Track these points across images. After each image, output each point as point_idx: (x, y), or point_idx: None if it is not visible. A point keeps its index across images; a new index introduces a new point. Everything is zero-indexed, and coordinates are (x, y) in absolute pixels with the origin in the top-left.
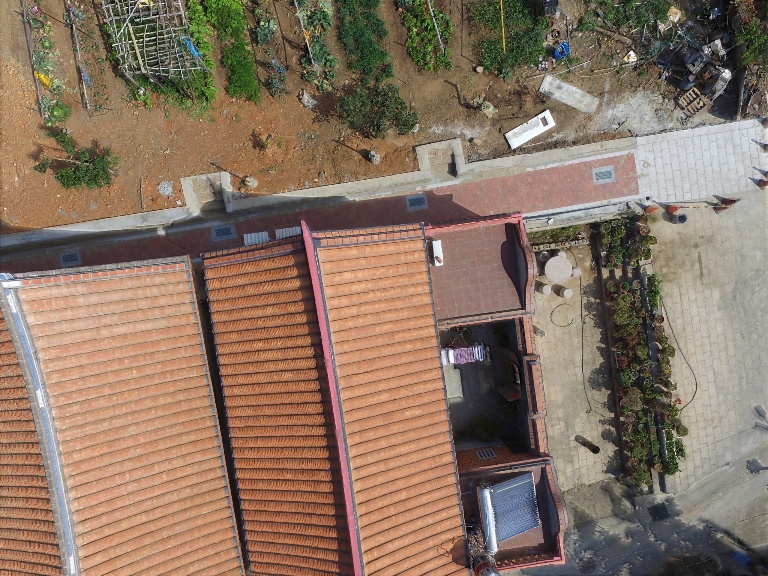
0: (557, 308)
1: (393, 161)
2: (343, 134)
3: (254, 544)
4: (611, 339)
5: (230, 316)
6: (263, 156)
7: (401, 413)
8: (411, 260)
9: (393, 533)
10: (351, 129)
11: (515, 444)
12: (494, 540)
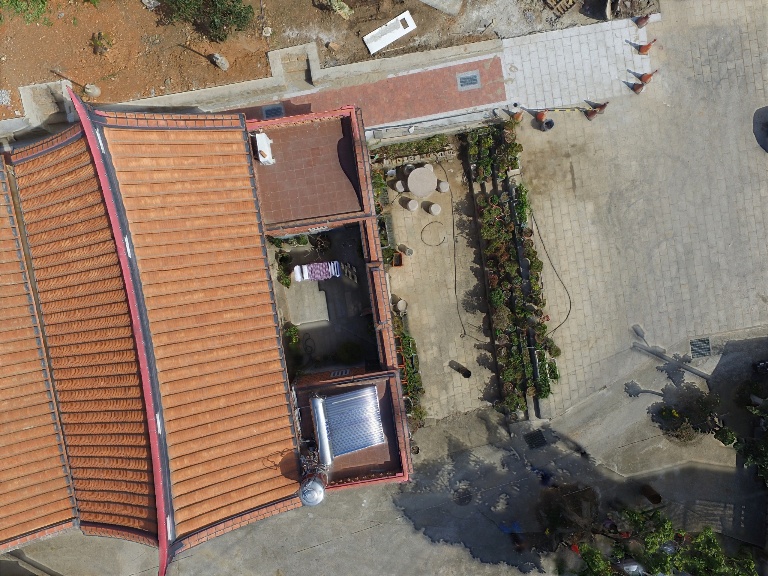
0: (427, 226)
1: (243, 67)
2: (189, 38)
3: (75, 459)
4: (484, 258)
5: (39, 215)
6: (104, 62)
7: (218, 315)
8: (229, 152)
9: (208, 441)
10: (198, 33)
11: (375, 365)
12: (327, 453)
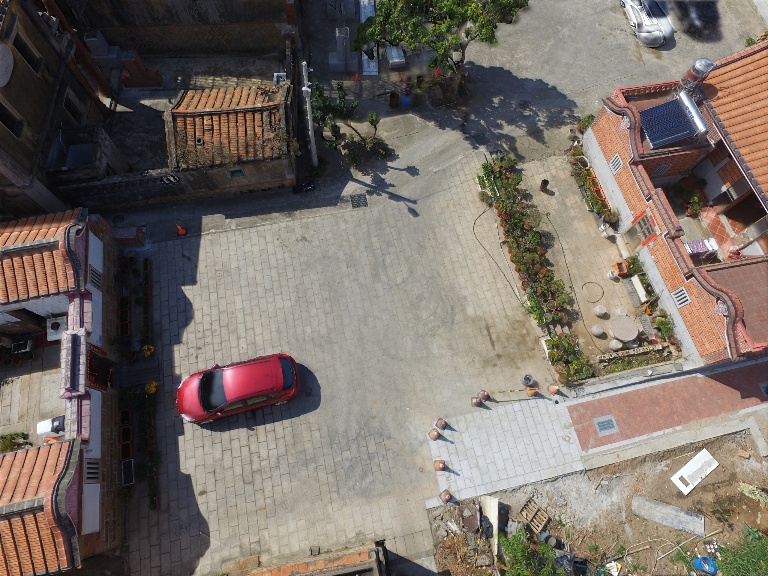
0: (600, 299)
1: None
2: None
3: None
4: None
5: None
6: None
7: None
8: None
9: None
10: None
11: None
12: (686, 99)
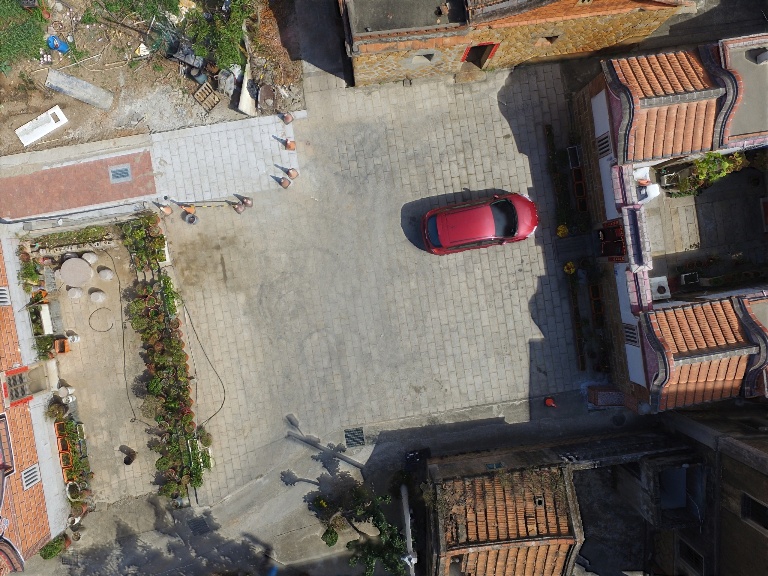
0: (95, 312)
1: None
2: None
3: None
4: None
5: None
6: None
7: None
8: None
9: None
10: None
11: None
12: None
